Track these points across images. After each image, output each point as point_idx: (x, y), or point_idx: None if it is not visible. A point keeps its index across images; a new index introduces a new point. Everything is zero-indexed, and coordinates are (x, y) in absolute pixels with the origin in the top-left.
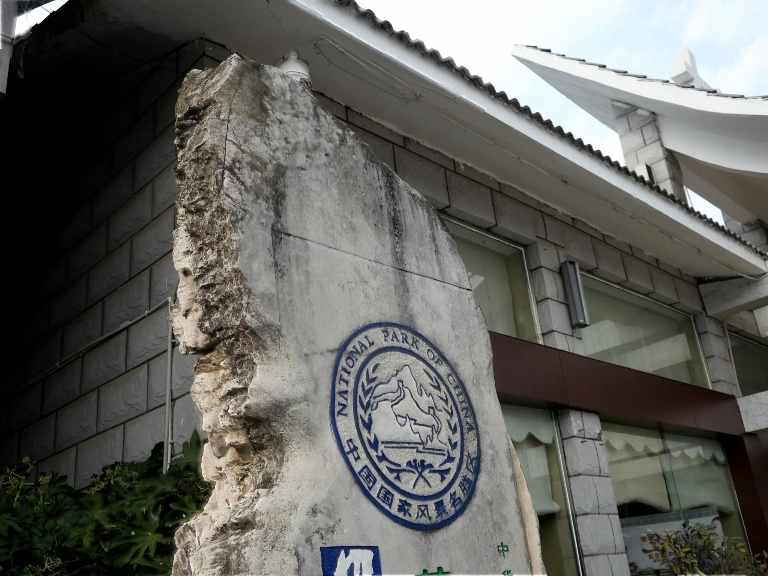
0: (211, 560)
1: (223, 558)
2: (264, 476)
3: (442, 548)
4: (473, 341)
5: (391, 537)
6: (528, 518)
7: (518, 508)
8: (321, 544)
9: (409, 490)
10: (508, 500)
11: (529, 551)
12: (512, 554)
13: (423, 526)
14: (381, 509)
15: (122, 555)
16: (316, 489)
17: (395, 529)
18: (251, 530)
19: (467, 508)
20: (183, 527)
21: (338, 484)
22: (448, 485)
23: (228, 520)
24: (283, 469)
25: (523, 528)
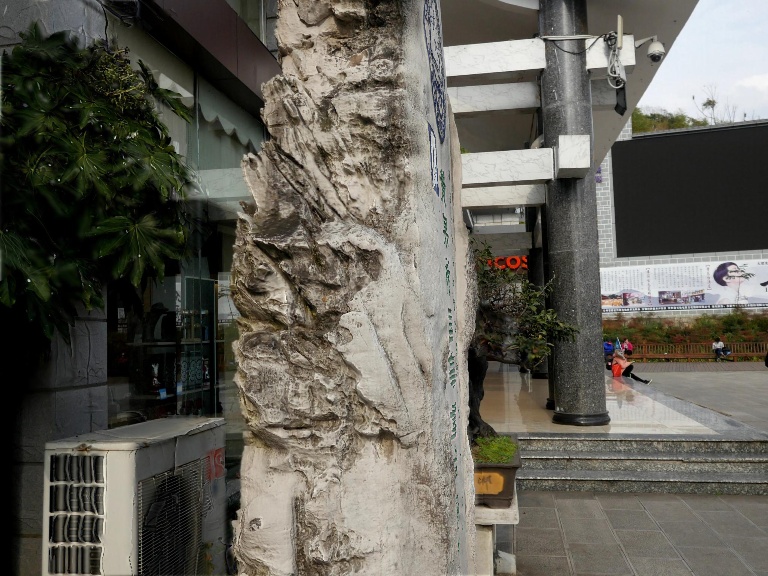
0: (375, 103)
1: (385, 104)
2: (385, 49)
3: None
4: (439, 3)
5: None
6: (456, 160)
7: (450, 151)
8: None
9: None
10: None
11: (453, 185)
12: (450, 182)
13: None
14: (435, 110)
15: (23, 124)
16: None
17: None
18: (399, 88)
19: None
20: (279, 80)
21: None
22: None
23: (367, 77)
24: (403, 48)
25: (451, 167)
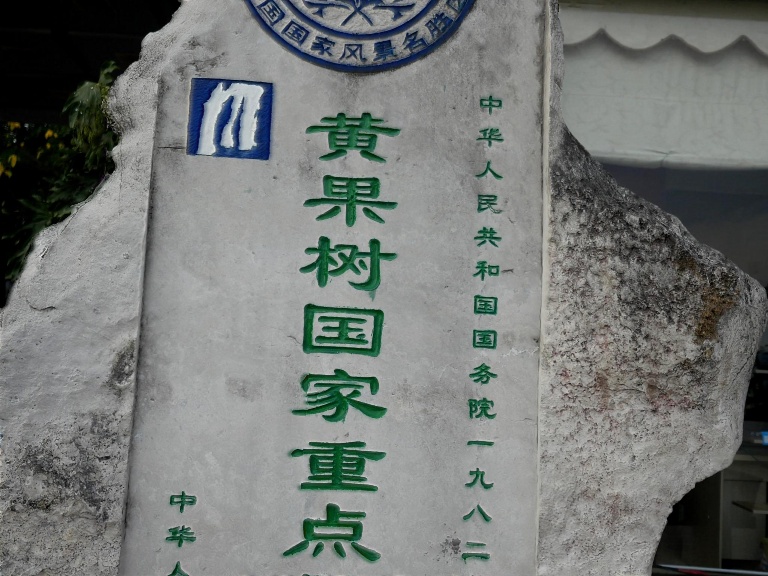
0: None
1: None
2: None
3: (376, 93)
4: None
5: (294, 75)
6: (547, 68)
7: (539, 57)
8: (194, 75)
9: (335, 27)
10: (520, 47)
11: (543, 110)
12: (508, 111)
13: (348, 67)
14: (285, 45)
15: None
16: (199, 22)
17: (303, 68)
18: None
19: (434, 52)
20: None
21: (226, 17)
22: (404, 24)
23: None
24: (177, 7)
25: (541, 82)
